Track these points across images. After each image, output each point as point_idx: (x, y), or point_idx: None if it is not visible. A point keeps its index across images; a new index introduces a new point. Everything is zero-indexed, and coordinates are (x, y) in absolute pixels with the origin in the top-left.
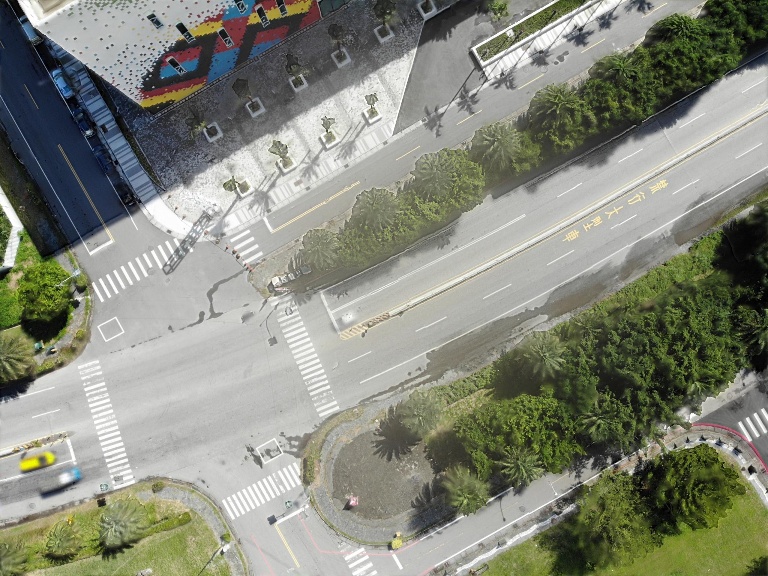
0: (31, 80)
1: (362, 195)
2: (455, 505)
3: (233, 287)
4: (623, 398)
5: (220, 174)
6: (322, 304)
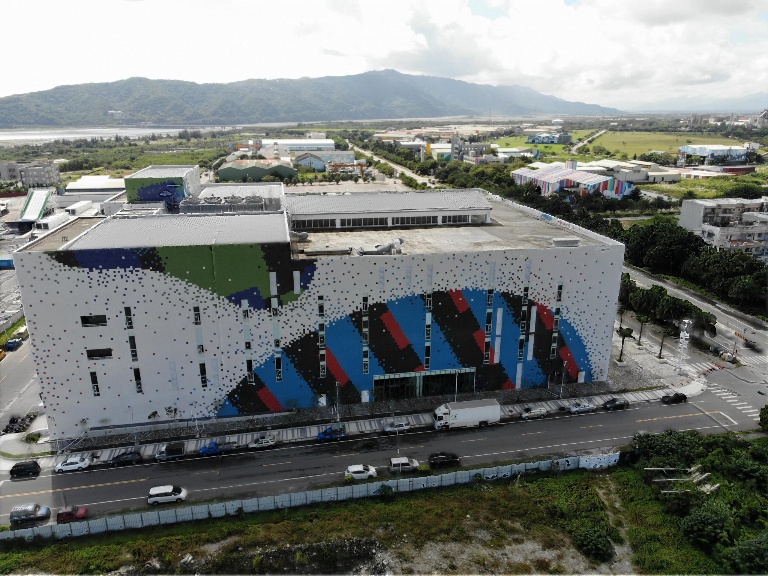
0: (576, 425)
1: (664, 310)
2: None
3: (740, 374)
4: (759, 267)
5: (651, 366)
6: None
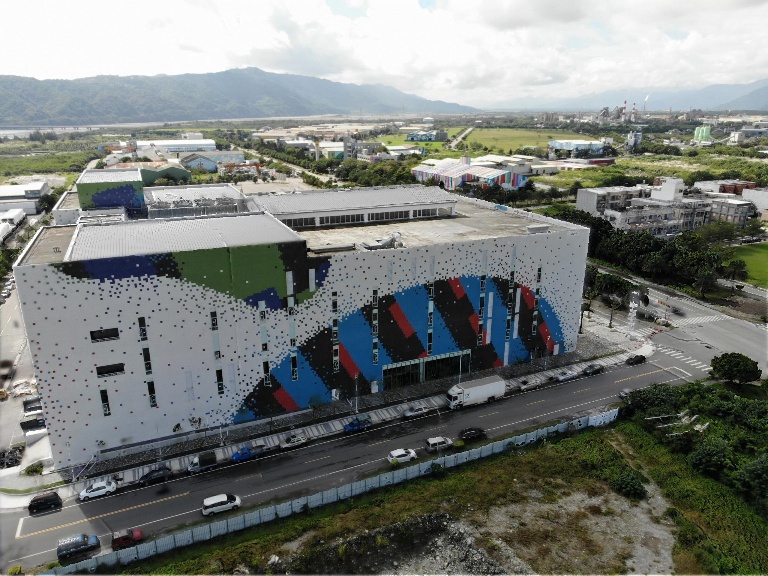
0: (568, 391)
1: None
2: (743, 263)
3: (676, 335)
4: None
5: None
6: (666, 315)
